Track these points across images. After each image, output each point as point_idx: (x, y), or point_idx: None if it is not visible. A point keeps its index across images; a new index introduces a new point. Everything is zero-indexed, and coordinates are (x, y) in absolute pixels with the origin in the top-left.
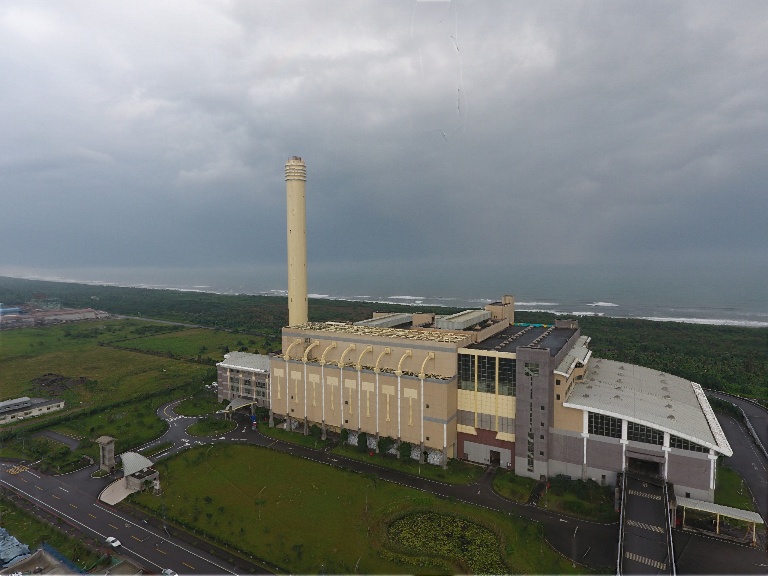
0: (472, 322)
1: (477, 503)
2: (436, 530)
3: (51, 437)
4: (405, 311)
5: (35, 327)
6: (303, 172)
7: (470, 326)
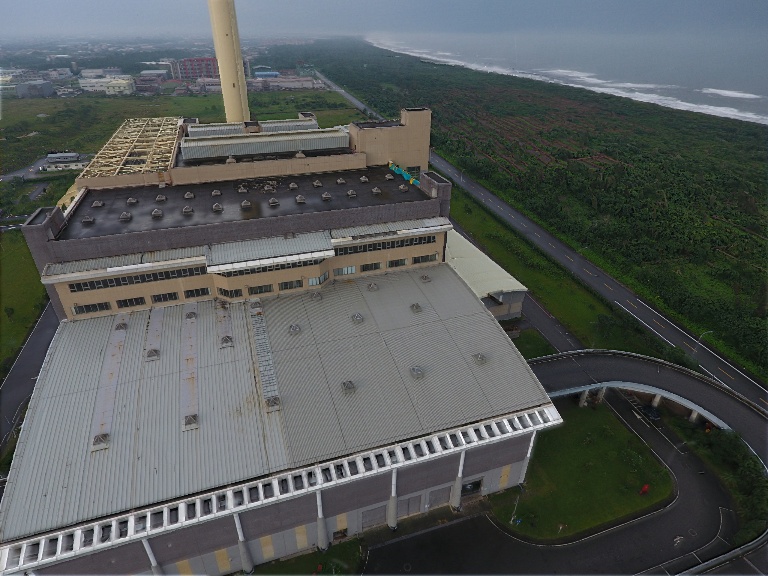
0: (241, 150)
1: (3, 387)
2: None
3: (37, 189)
4: (644, 116)
5: (257, 92)
6: None
7: None
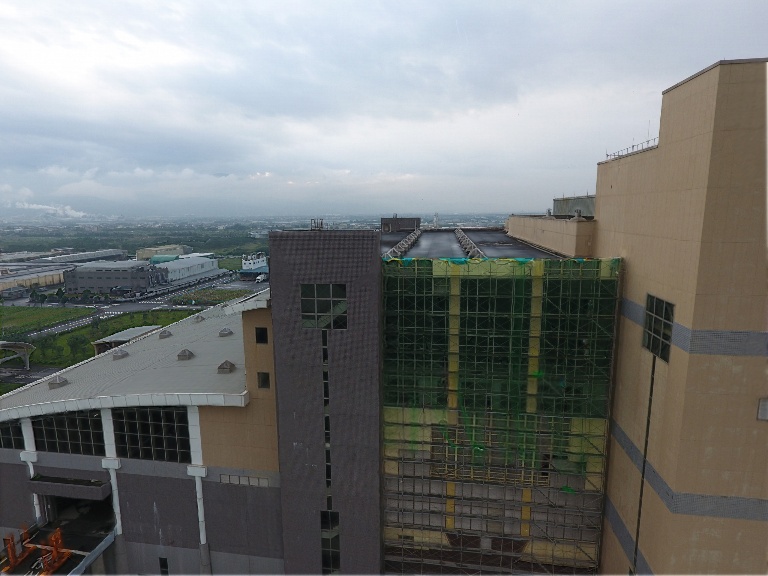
0: (575, 208)
1: None
2: None
3: None
4: None
5: None
6: None
7: (567, 215)
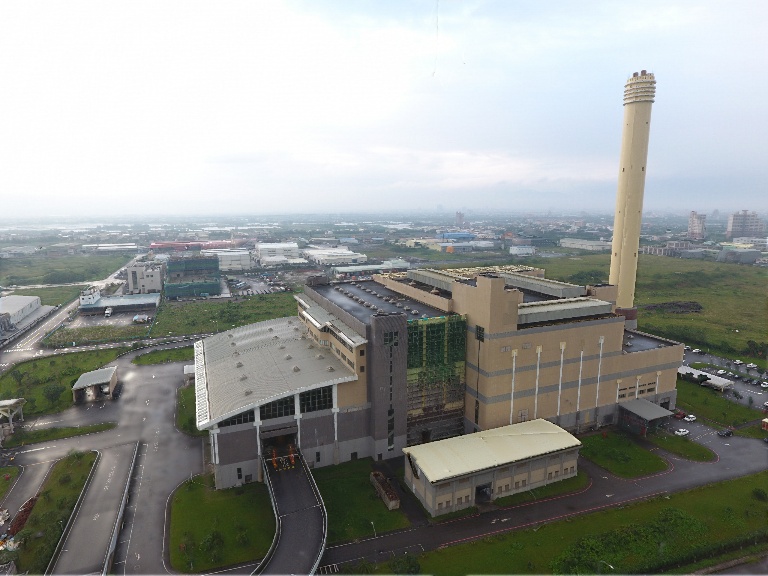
0: (424, 280)
1: None
2: None
3: None
4: None
5: None
6: (630, 92)
7: (420, 282)
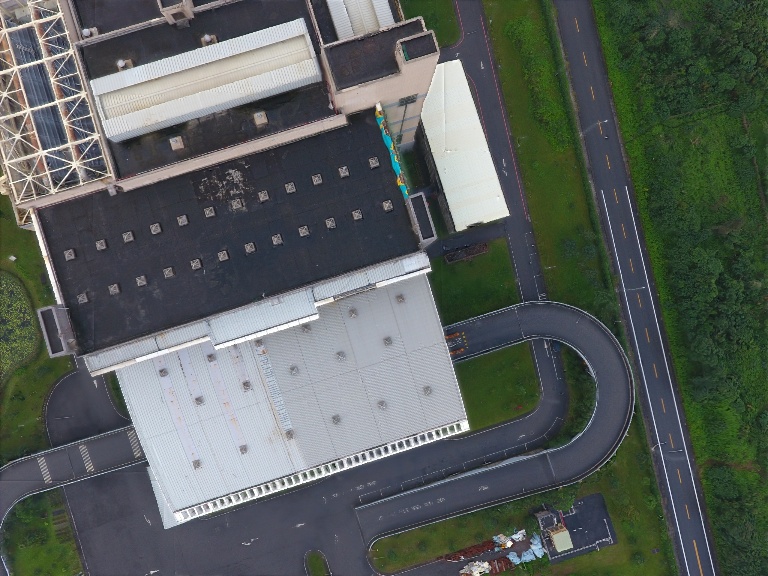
0: (182, 118)
1: None
2: (1, 309)
3: None
4: None
5: None
6: None
7: (169, 127)
